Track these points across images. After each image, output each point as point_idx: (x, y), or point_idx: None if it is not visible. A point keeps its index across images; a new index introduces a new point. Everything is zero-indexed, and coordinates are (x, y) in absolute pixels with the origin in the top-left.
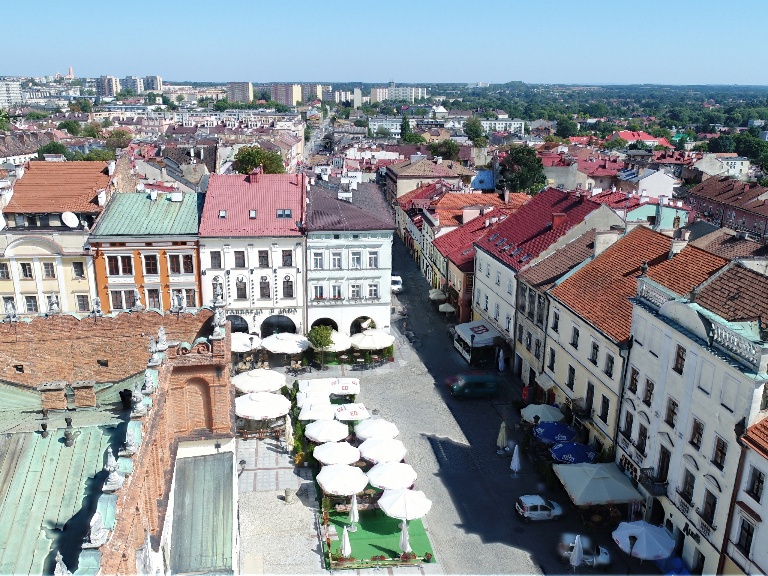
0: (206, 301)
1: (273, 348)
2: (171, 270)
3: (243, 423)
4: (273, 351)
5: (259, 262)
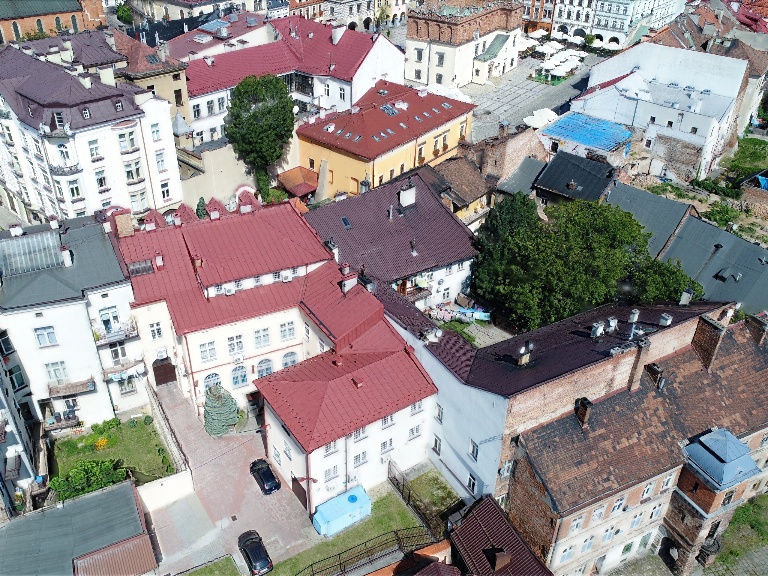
0: (555, 17)
1: (570, 40)
2: (546, 1)
3: (538, 55)
4: (570, 41)
5: (579, 3)
